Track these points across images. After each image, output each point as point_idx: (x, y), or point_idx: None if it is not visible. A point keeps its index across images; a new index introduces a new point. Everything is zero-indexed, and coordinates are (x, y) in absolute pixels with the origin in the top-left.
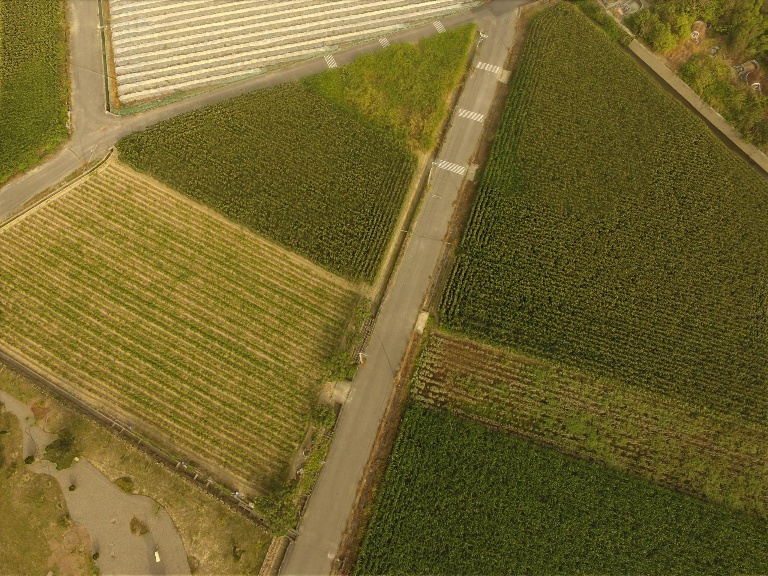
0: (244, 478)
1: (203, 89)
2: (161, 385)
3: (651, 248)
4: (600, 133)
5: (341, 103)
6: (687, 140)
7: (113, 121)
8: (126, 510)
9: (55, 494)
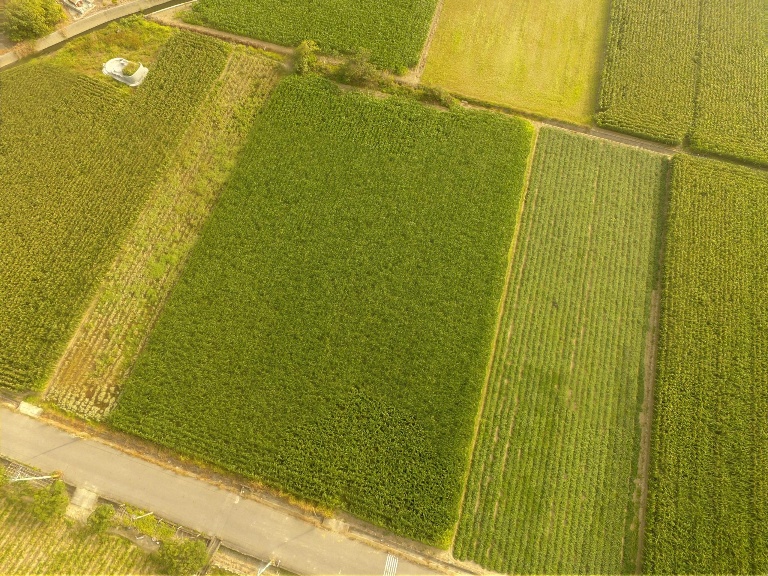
0: None
1: None
2: None
3: (8, 185)
4: None
5: None
6: None
7: None
8: None
9: None
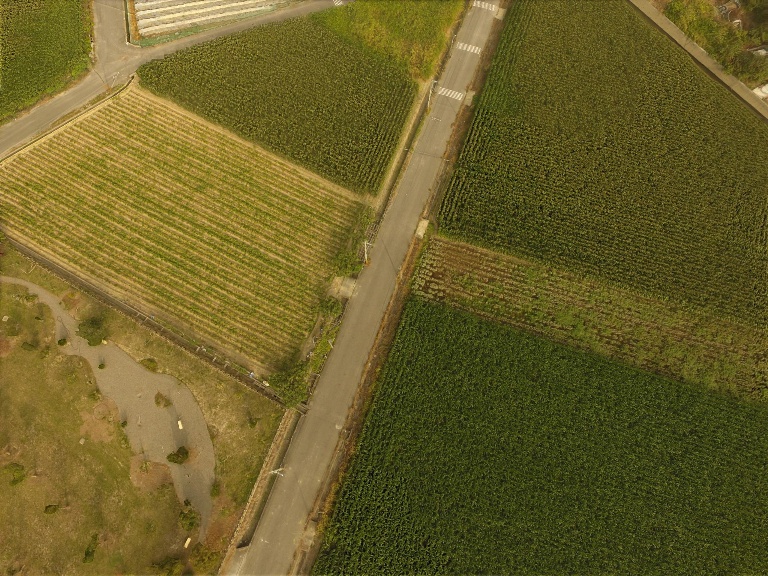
0: (258, 361)
1: (217, 24)
2: (181, 281)
3: (636, 163)
4: (589, 63)
5: (347, 36)
6: (671, 69)
7: (133, 51)
8: (151, 386)
9: (86, 372)
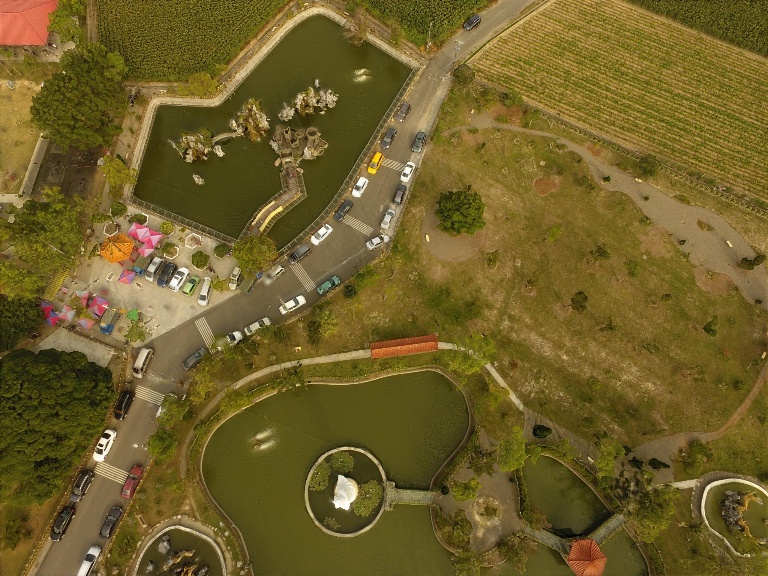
0: None
1: None
2: (678, 137)
3: None
4: None
5: None
6: None
7: None
8: (691, 215)
9: (630, 204)
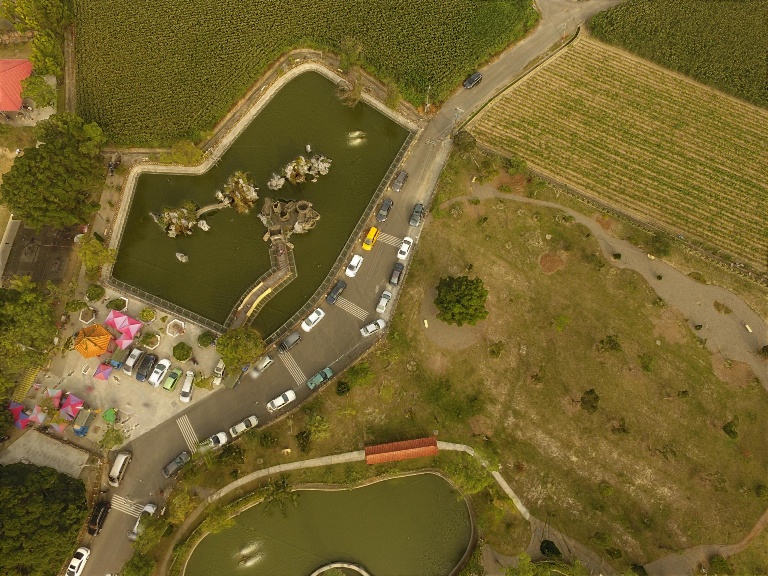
0: None
1: None
2: (692, 207)
3: None
4: None
5: None
6: None
7: (572, 5)
8: (707, 296)
9: (642, 283)
